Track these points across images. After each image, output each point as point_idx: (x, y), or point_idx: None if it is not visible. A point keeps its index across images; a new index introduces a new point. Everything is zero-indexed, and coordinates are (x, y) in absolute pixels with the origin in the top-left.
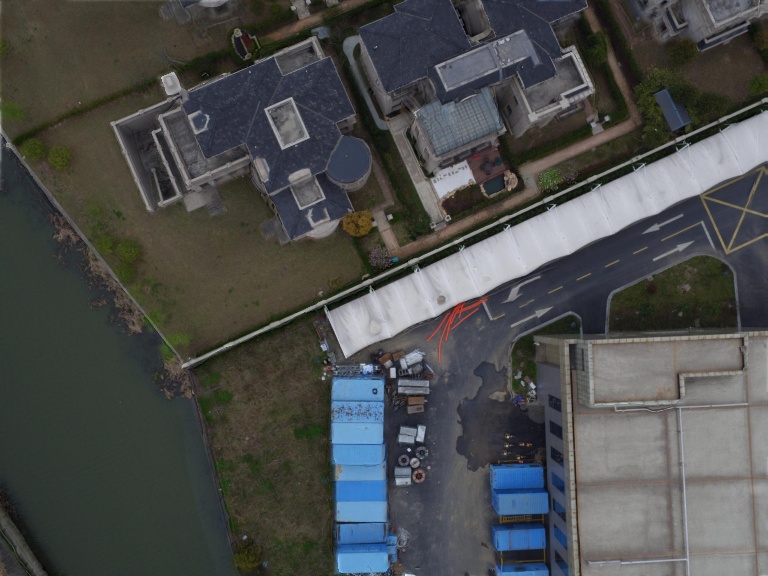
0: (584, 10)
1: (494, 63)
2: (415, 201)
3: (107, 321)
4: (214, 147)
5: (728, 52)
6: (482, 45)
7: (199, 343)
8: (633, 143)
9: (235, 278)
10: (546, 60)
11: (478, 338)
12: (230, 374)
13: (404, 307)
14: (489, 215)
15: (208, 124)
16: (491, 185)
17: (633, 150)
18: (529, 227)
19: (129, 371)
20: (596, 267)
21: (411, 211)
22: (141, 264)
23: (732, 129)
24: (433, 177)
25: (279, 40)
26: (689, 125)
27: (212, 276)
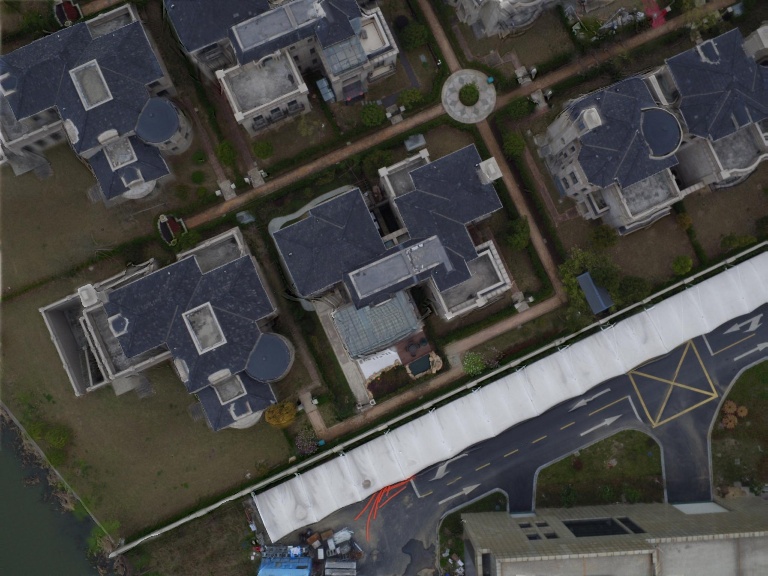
0: (499, 210)
1: (407, 270)
2: (341, 382)
3: (40, 499)
4: (134, 348)
5: (650, 235)
6: (396, 251)
7: (129, 526)
8: (558, 322)
9: (164, 460)
10: (460, 265)
11: (406, 516)
12: (160, 555)
13: (330, 492)
14: (415, 395)
15: (127, 327)
16: (417, 365)
17: (558, 330)
18: (454, 410)
19: (62, 548)
20: (523, 444)
21: (336, 394)
22: (71, 447)
23: (656, 310)
24: (359, 358)
25: (205, 223)
26: (613, 307)
27: (141, 459)
